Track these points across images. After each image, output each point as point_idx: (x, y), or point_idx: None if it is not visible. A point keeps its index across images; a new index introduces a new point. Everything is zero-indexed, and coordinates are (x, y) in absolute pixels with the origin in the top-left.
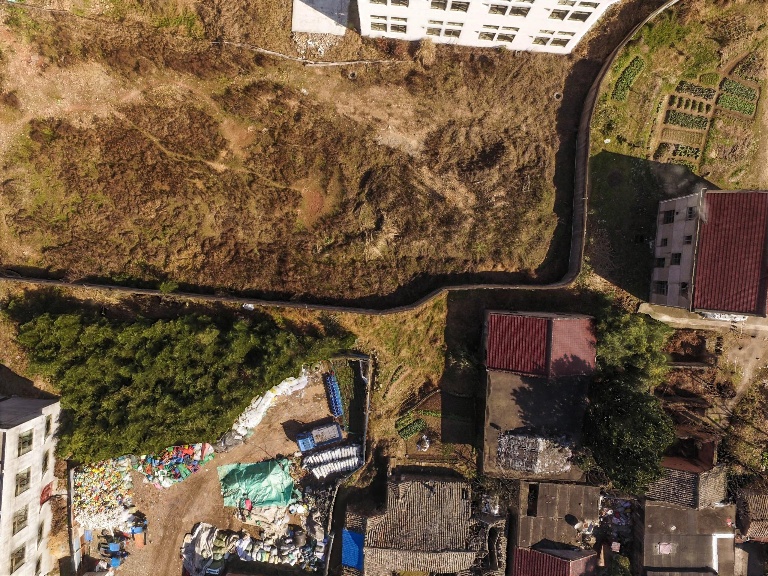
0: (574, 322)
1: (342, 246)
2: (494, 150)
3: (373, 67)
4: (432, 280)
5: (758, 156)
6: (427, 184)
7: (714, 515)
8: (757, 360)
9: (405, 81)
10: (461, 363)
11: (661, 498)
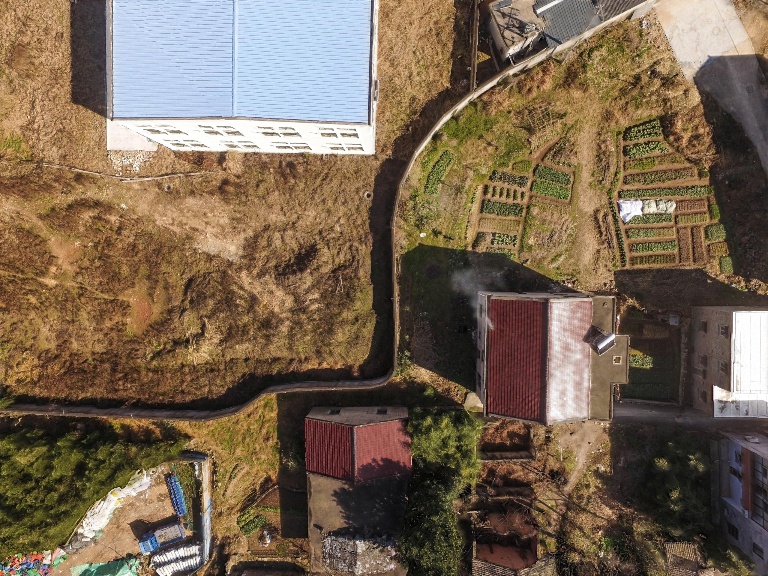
0: (382, 425)
1: (169, 353)
2: (308, 252)
3: (187, 179)
4: (259, 381)
5: (577, 240)
6: (247, 288)
7: None
8: (589, 445)
9: (219, 190)
10: (289, 463)
11: None
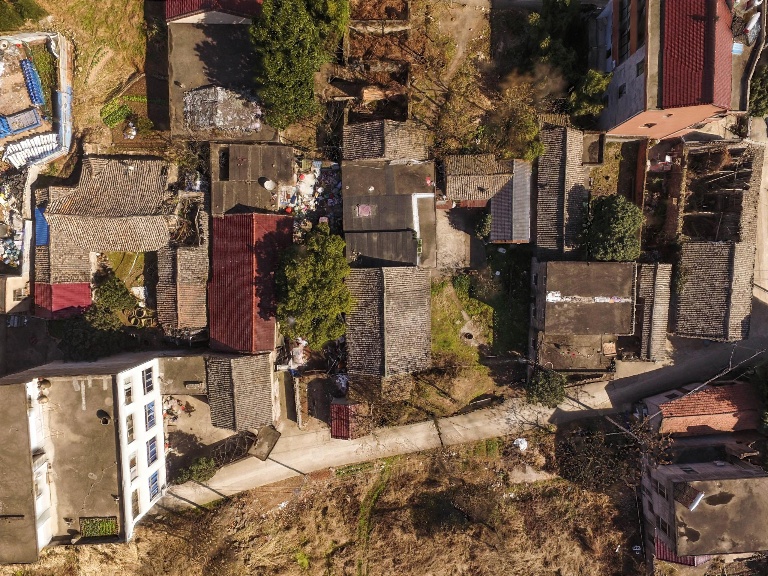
0: None
1: None
2: None
3: None
4: None
5: None
6: None
7: (412, 173)
8: (470, 31)
9: None
10: (153, 31)
11: (356, 156)
